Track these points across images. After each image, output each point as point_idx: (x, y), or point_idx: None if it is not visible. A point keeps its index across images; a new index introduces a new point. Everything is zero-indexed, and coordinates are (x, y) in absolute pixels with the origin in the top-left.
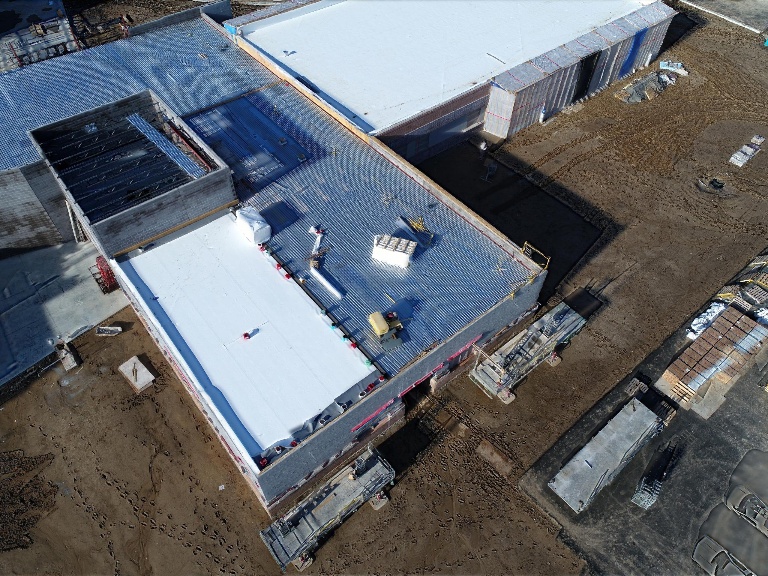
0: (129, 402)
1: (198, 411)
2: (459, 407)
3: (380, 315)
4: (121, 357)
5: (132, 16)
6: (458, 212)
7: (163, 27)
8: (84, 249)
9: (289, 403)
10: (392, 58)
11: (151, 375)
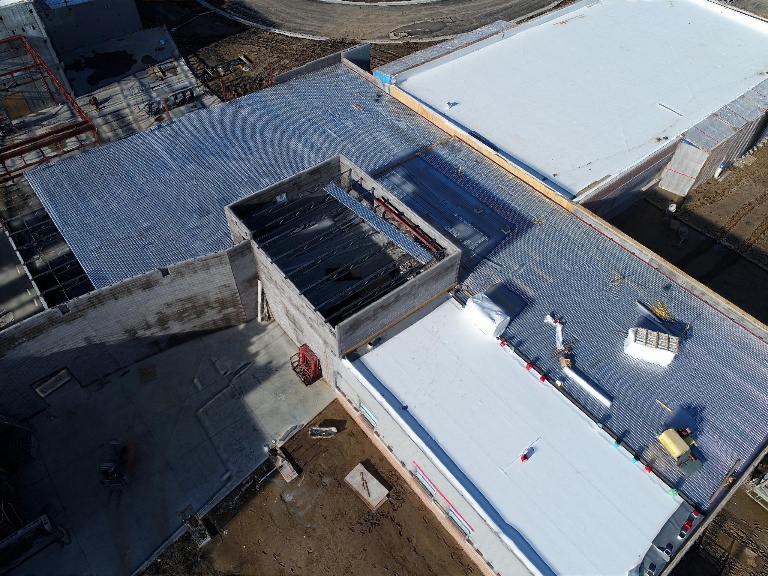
0: (367, 522)
1: (448, 534)
2: (738, 528)
3: (675, 433)
4: (343, 464)
5: (250, 56)
6: (699, 295)
7: (305, 74)
8: (269, 330)
9: (602, 547)
10: (561, 110)
11: (384, 488)
